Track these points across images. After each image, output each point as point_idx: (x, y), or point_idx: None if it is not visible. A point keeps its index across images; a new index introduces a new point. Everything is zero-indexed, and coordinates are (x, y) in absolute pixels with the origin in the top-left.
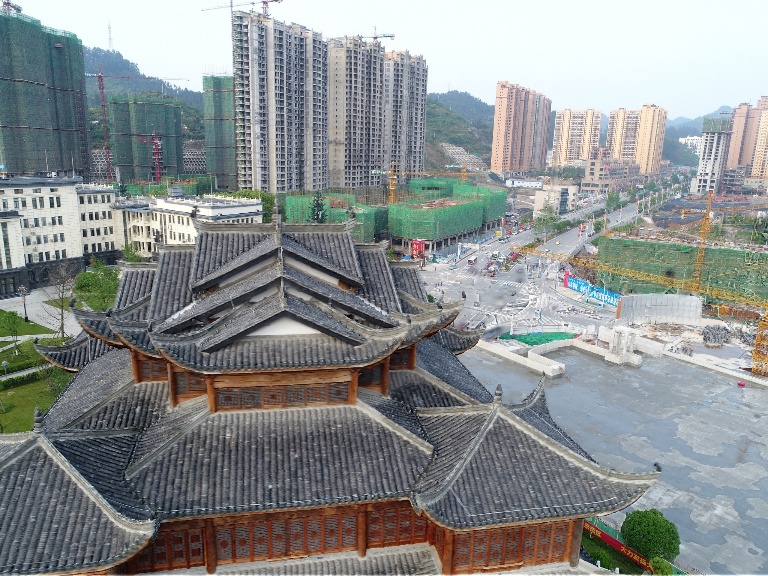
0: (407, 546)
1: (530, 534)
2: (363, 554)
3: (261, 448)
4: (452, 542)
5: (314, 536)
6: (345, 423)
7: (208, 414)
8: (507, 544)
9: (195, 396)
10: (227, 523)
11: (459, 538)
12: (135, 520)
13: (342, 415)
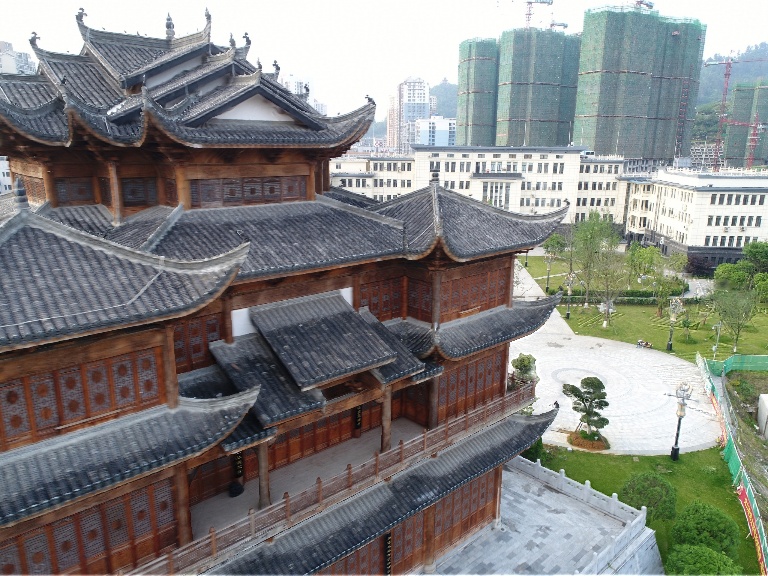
0: None
1: None
2: None
3: None
4: None
5: None
6: None
7: (11, 196)
8: None
9: None
10: None
11: None
12: None
13: None
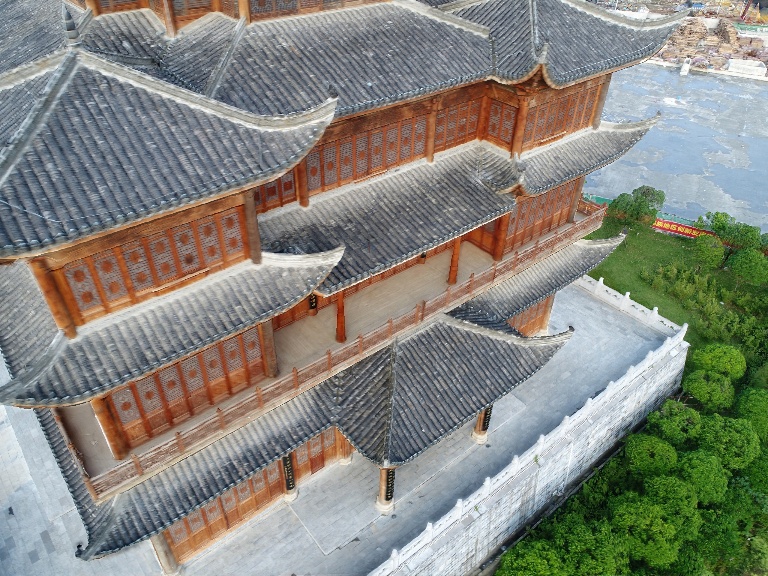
0: (463, 145)
1: (574, 102)
2: (432, 159)
3: (330, 52)
4: (526, 117)
5: (392, 147)
6: (394, 19)
7: (245, 25)
8: (558, 114)
9: (196, 17)
10: (318, 144)
11: (529, 113)
12: (299, 111)
13: (385, 12)
